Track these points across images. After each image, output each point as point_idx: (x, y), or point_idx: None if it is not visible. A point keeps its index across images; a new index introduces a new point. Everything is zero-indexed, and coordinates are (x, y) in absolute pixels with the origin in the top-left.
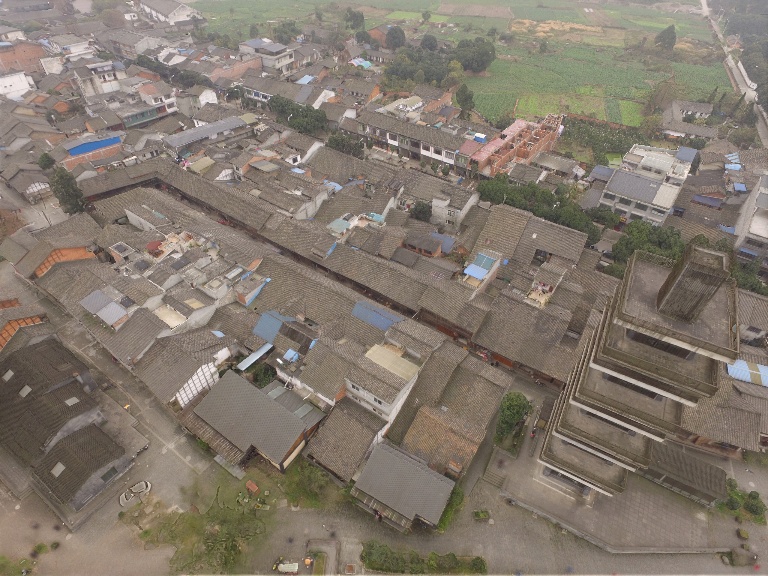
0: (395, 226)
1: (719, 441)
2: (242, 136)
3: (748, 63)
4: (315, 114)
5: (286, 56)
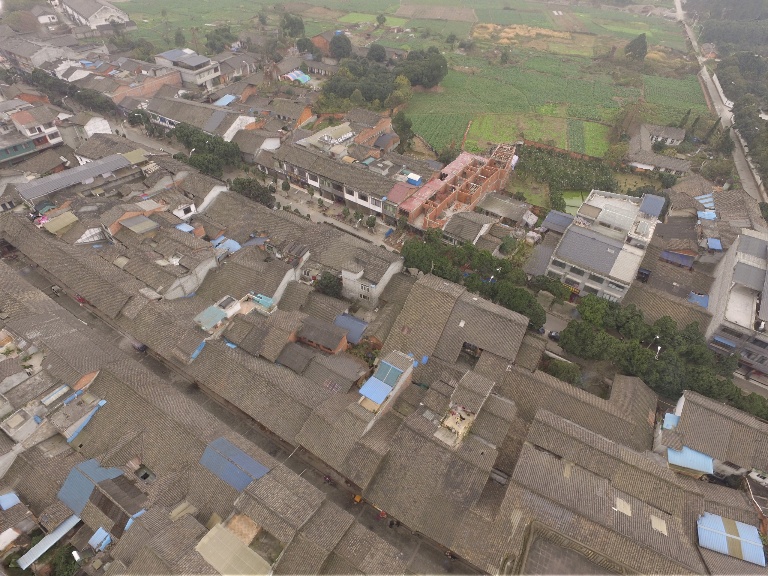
0: (293, 306)
1: None
2: (127, 179)
3: (724, 78)
4: (222, 148)
5: (210, 70)
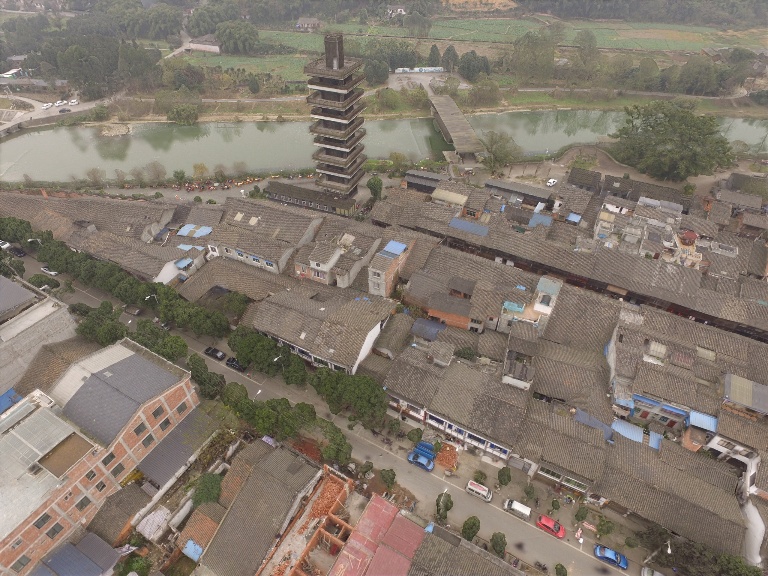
0: (491, 335)
1: None
2: None
3: None
4: None
5: None
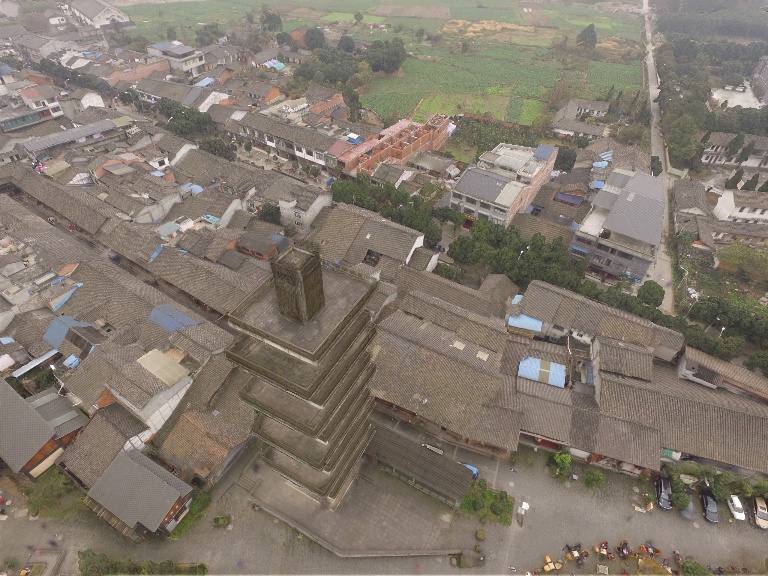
0: (238, 228)
1: (480, 441)
2: (114, 139)
3: (659, 61)
4: (196, 116)
5: (195, 58)
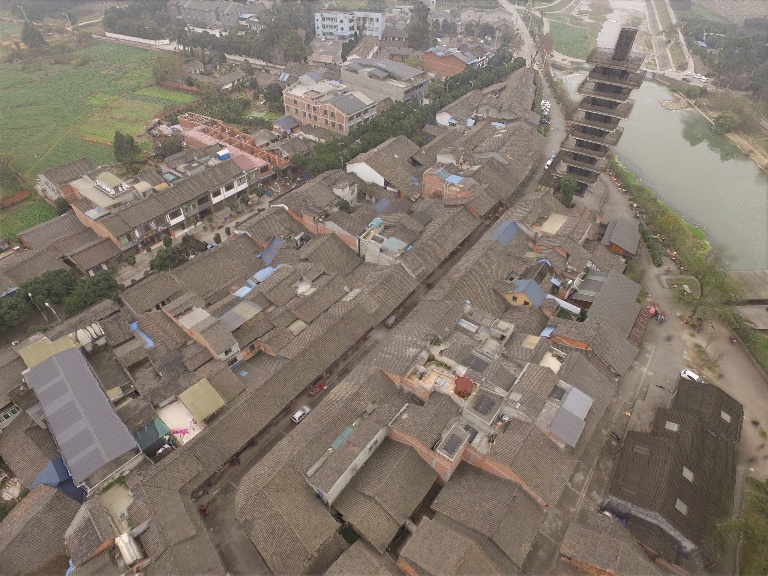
0: None
1: None
2: None
3: (131, 29)
4: (68, 275)
5: None
